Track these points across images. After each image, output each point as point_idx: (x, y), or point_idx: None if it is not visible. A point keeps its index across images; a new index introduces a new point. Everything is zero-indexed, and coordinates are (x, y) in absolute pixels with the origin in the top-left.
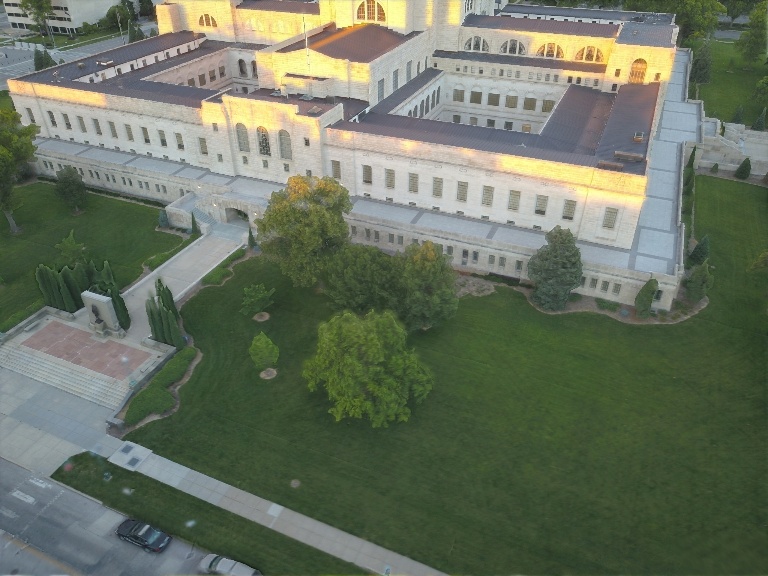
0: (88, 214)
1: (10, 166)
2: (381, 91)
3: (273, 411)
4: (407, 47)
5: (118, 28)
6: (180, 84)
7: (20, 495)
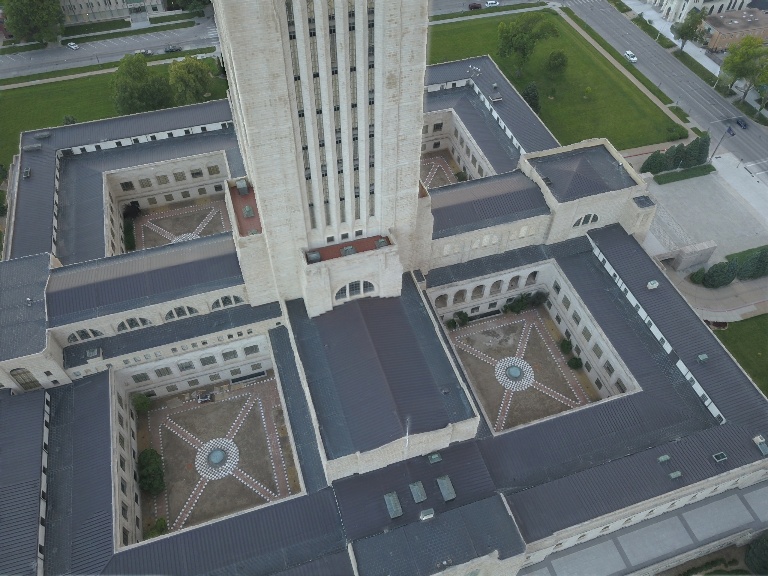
0: None
1: None
2: None
3: (168, 77)
4: None
5: None
6: None
7: (217, 42)
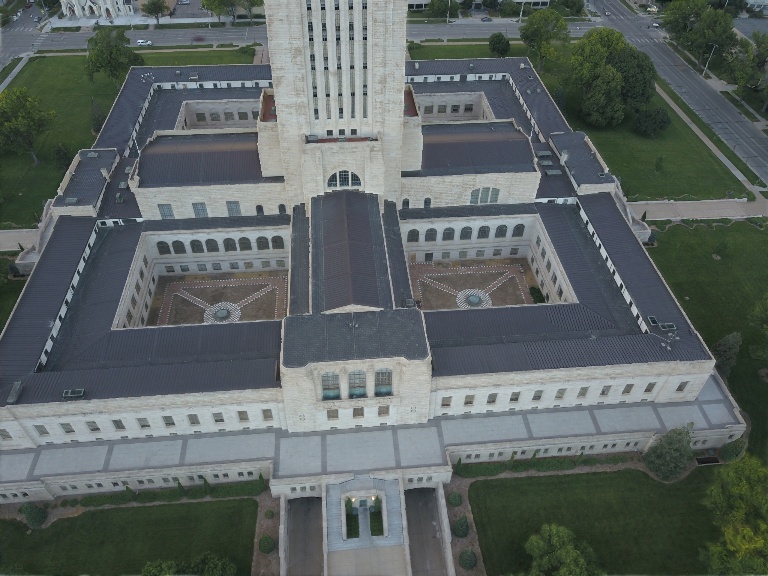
0: (63, 175)
1: (12, 132)
2: (171, 212)
3: None
4: (224, 189)
5: (437, 15)
6: (230, 113)
7: None
